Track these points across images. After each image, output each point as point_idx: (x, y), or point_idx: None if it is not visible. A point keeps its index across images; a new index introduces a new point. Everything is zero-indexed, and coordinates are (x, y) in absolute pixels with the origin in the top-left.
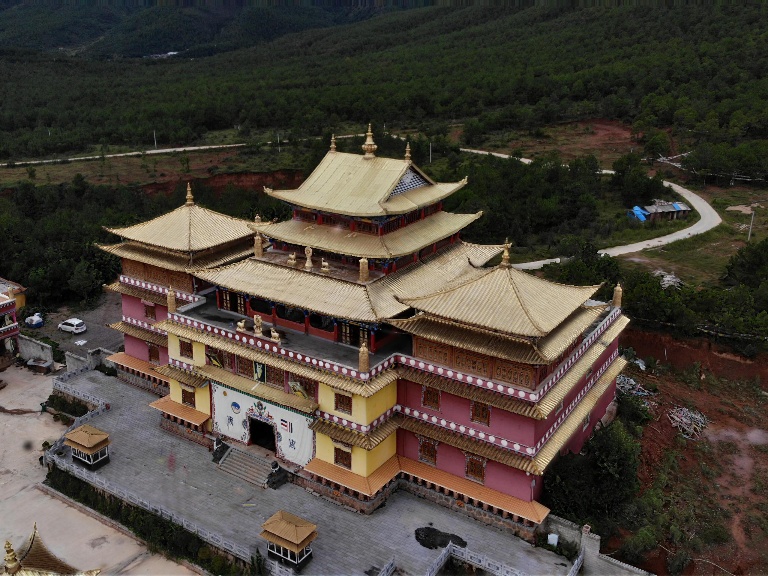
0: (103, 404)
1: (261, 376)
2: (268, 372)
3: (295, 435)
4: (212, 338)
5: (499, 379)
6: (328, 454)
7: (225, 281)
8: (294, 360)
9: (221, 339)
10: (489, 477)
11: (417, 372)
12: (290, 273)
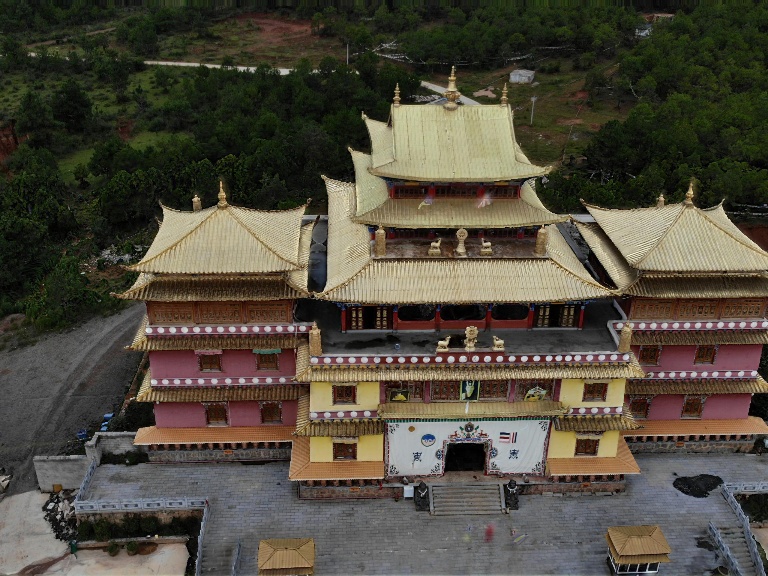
0: (191, 504)
1: (472, 394)
2: (481, 387)
3: (520, 444)
4: (399, 370)
5: (727, 317)
6: (567, 449)
7: (368, 296)
8: (529, 364)
9: (411, 368)
10: (707, 410)
11: (638, 334)
12: (444, 265)
